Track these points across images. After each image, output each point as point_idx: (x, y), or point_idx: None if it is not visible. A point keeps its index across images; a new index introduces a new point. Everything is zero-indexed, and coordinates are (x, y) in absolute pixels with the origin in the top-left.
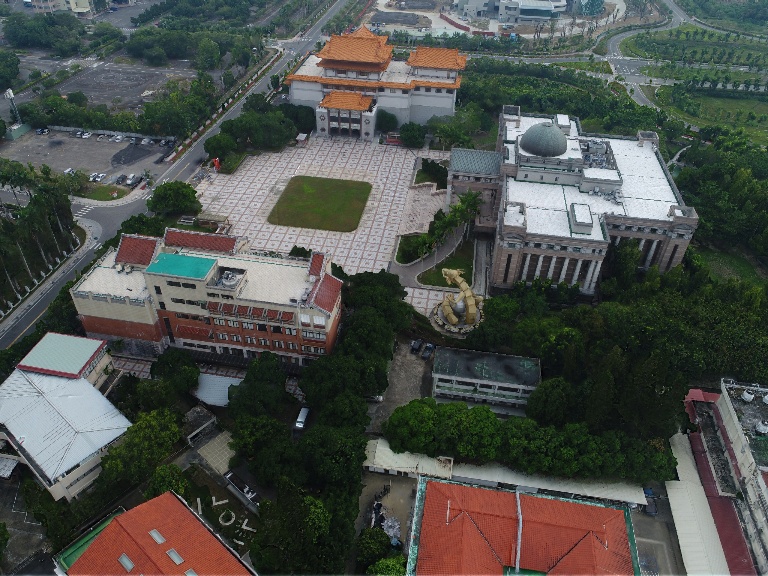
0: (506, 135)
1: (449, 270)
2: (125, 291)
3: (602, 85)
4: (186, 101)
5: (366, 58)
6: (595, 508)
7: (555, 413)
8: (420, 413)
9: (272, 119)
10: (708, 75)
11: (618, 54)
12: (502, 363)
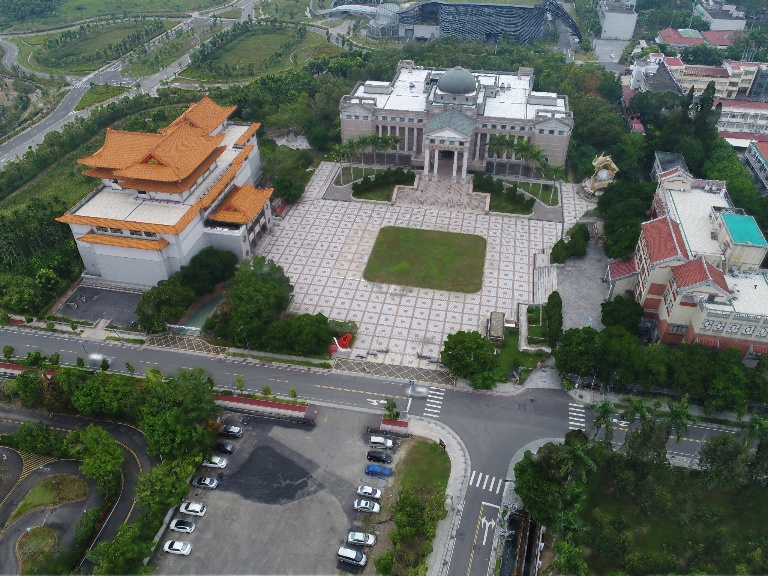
0: (393, 111)
1: (598, 161)
2: (760, 289)
3: (169, 94)
4: (116, 390)
5: (207, 147)
6: (760, 147)
7: (702, 150)
8: (744, 182)
9: (262, 270)
10: (196, 49)
11: (74, 78)
12: (666, 163)
